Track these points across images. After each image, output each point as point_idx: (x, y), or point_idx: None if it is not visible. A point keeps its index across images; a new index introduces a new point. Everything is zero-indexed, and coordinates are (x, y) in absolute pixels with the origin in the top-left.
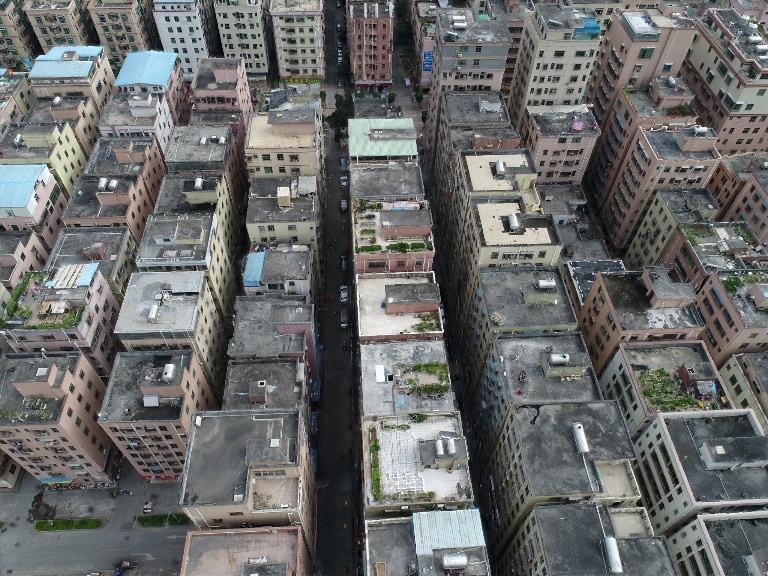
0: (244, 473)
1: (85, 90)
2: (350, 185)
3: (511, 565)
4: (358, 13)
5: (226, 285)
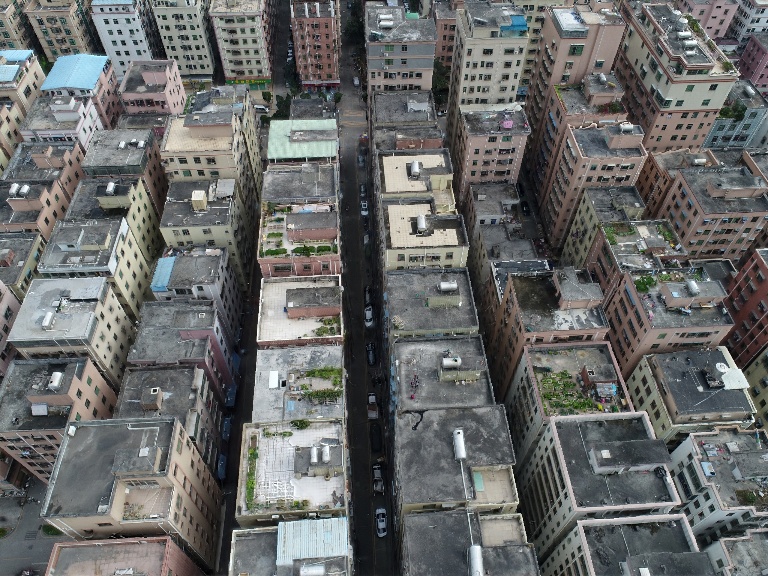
0: (112, 483)
1: (12, 95)
2: None
3: (400, 572)
4: (300, 13)
5: (142, 290)
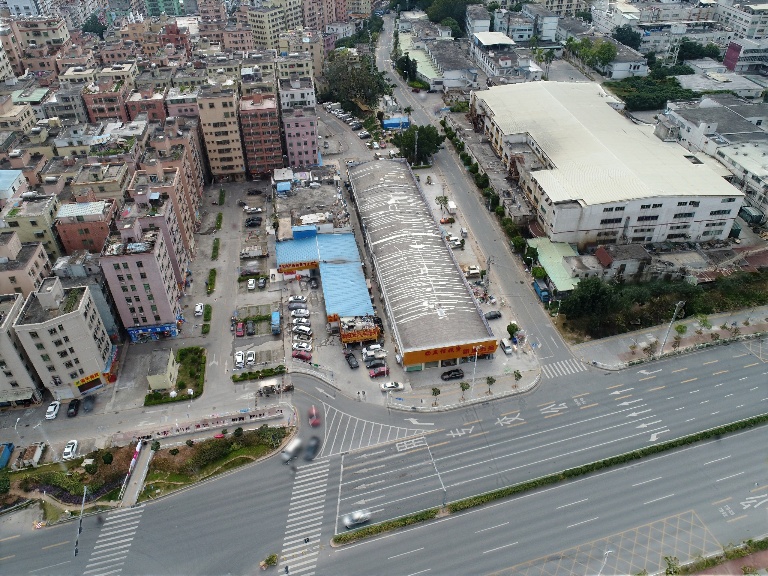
0: None
1: None
2: (68, 95)
3: None
4: None
5: None
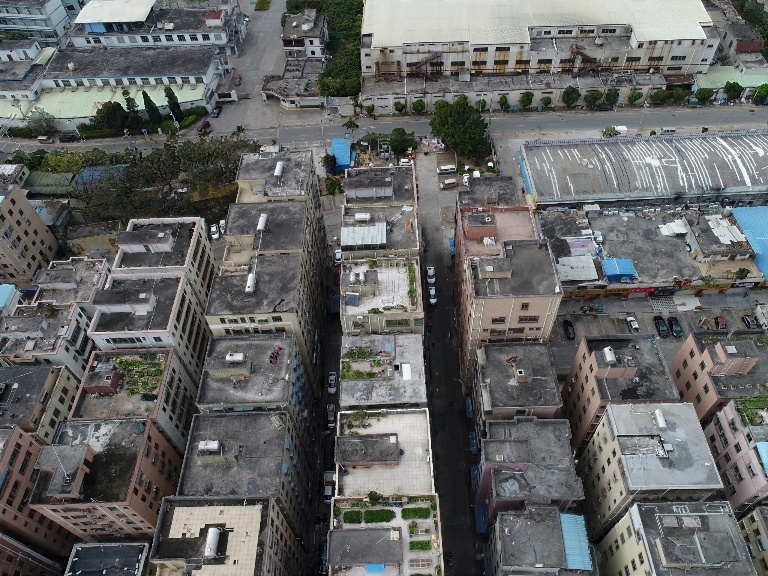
0: None
1: None
2: None
3: None
4: None
5: None
